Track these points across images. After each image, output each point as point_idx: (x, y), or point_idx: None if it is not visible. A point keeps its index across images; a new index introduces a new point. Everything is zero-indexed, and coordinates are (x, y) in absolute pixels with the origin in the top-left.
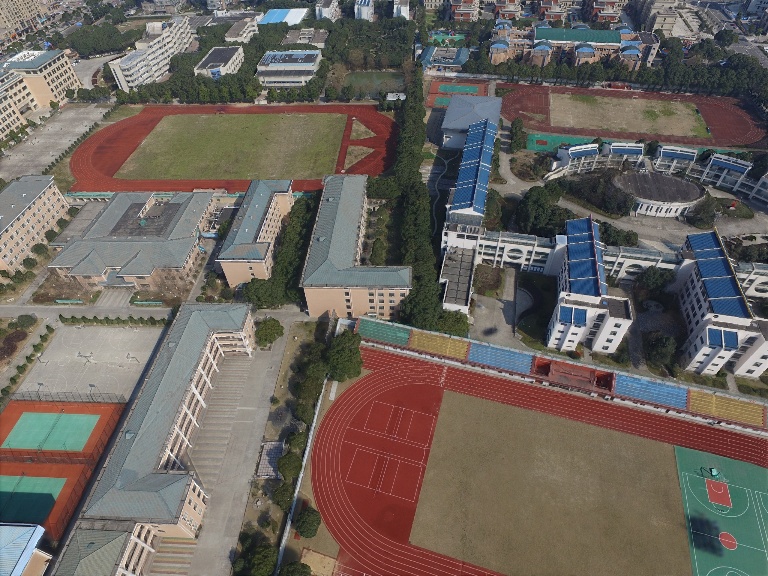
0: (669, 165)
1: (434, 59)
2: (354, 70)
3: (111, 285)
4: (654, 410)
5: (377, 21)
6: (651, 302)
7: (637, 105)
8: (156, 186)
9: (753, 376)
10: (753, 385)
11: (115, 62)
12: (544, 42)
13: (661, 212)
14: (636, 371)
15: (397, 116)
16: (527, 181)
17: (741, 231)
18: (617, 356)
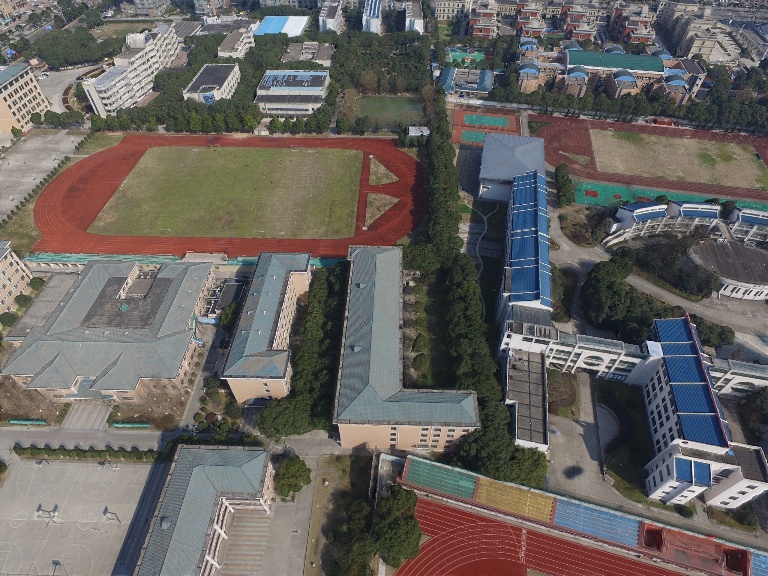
0: (747, 230)
1: (455, 83)
2: (366, 94)
3: (83, 398)
4: None
5: (388, 35)
6: (763, 426)
7: (689, 146)
8: (140, 245)
9: None
10: None
11: (89, 82)
12: (579, 68)
13: (749, 295)
14: (767, 537)
15: (421, 154)
16: (583, 246)
17: None
18: (738, 513)
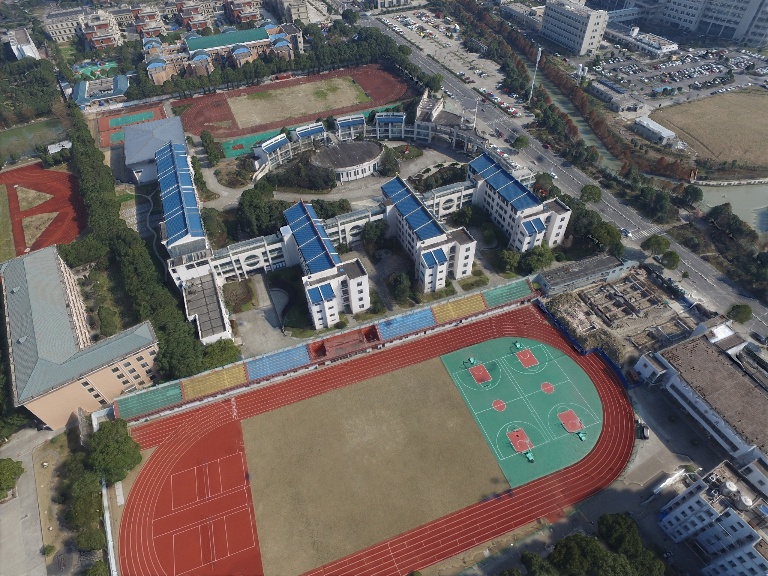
0: (349, 133)
1: (90, 95)
2: None
3: None
4: (416, 337)
5: None
6: (381, 251)
7: (306, 89)
8: None
9: (468, 275)
10: (470, 281)
11: None
12: (199, 52)
13: (359, 174)
14: (392, 313)
15: (71, 167)
16: (238, 188)
17: (419, 168)
18: (373, 308)
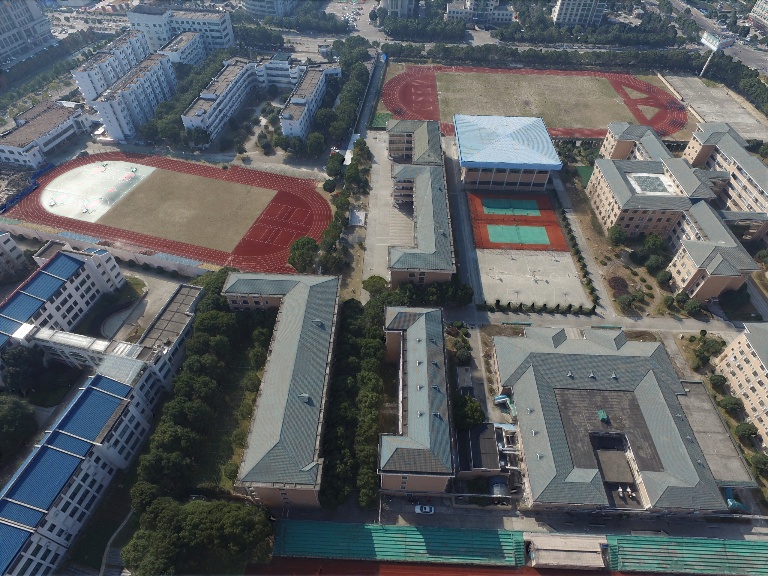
0: None
1: None
2: None
3: None
4: None
5: None
6: None
7: None
8: None
9: None
10: None
11: None
12: None
13: None
14: None
15: None
16: None
17: None
18: None
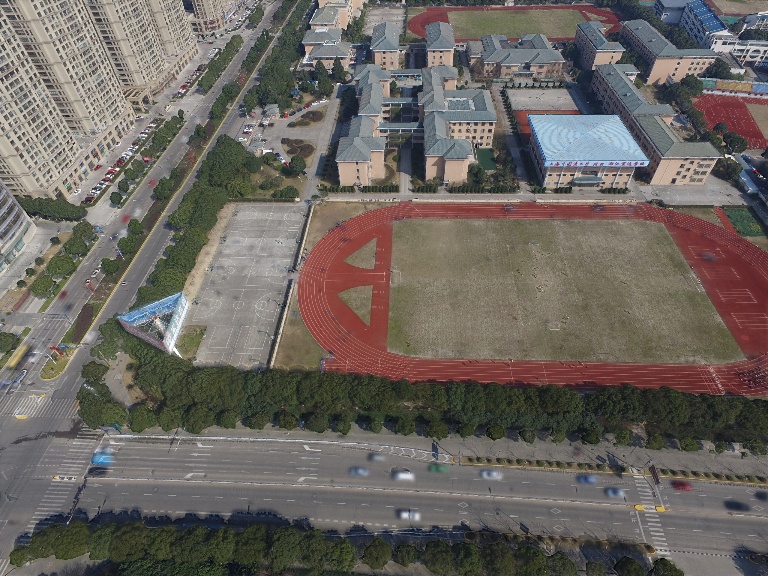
0: None
1: None
2: None
3: (521, 73)
4: None
5: None
6: None
7: None
8: None
9: None
10: None
11: None
12: None
13: None
14: None
15: (613, 10)
16: None
17: None
18: None
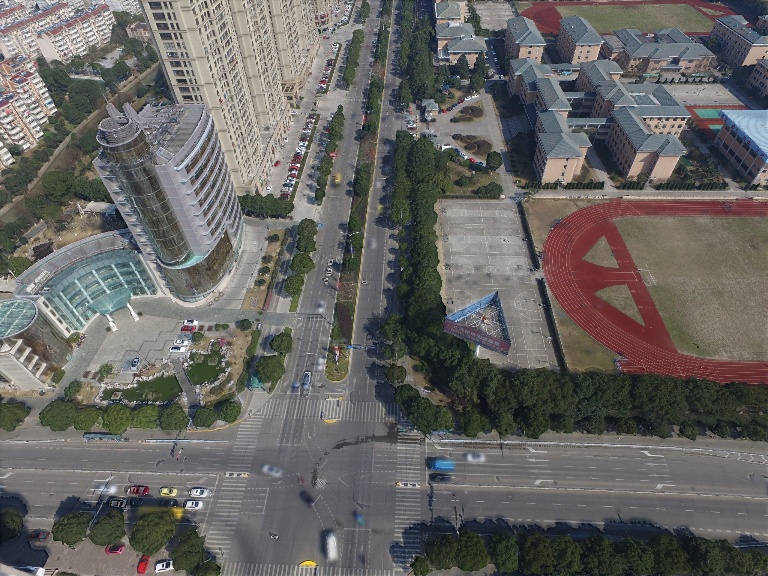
0: None
1: None
2: None
3: (669, 68)
4: None
5: None
6: None
7: None
8: None
9: None
10: None
11: None
12: None
13: None
14: None
15: (726, 5)
16: None
17: None
18: None
